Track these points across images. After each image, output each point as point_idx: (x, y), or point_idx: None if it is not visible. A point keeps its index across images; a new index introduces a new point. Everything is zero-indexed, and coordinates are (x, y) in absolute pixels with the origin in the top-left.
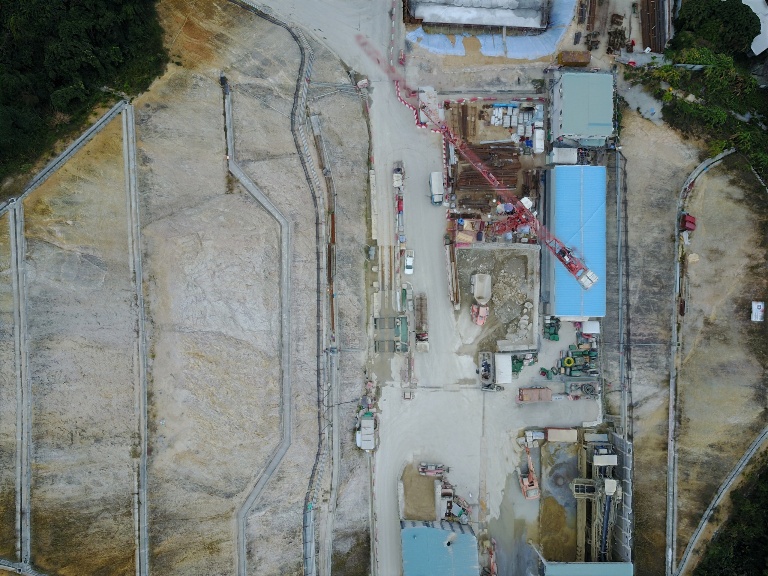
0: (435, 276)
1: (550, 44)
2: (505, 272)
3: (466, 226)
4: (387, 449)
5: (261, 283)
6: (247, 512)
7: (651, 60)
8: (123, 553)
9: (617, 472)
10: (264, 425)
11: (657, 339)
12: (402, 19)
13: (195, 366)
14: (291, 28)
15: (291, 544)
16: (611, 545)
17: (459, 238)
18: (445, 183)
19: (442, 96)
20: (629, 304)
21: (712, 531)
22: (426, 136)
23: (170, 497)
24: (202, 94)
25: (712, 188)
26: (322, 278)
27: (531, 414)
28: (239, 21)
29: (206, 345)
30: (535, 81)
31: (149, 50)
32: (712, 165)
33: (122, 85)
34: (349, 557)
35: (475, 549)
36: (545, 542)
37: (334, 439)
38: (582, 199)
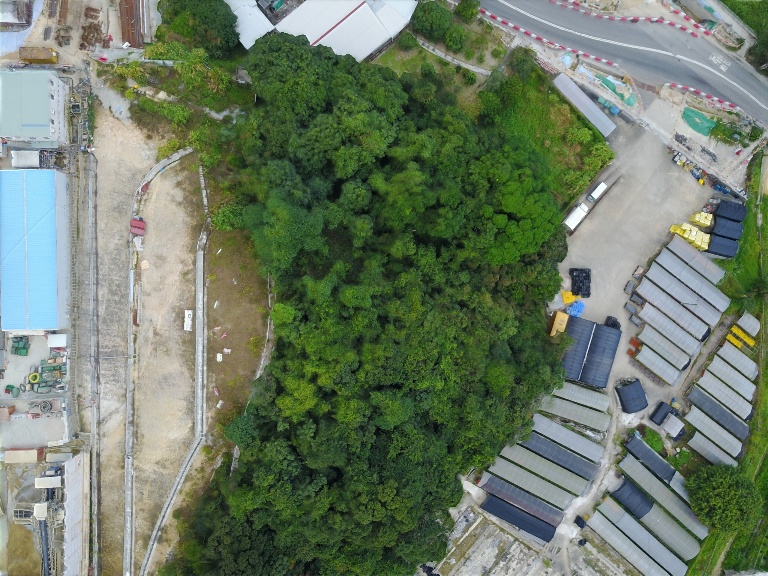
0: None
1: (21, 40)
2: None
3: None
4: None
5: None
6: None
7: (126, 56)
8: None
9: None
10: None
11: (118, 351)
12: None
13: None
14: None
15: None
16: (60, 572)
17: None
18: None
19: None
20: (98, 315)
21: (164, 552)
22: None
23: None
24: None
25: (162, 191)
26: None
27: None
28: None
29: None
30: None
31: None
32: (168, 166)
33: None
34: None
35: None
36: (10, 570)
37: None
38: (26, 205)
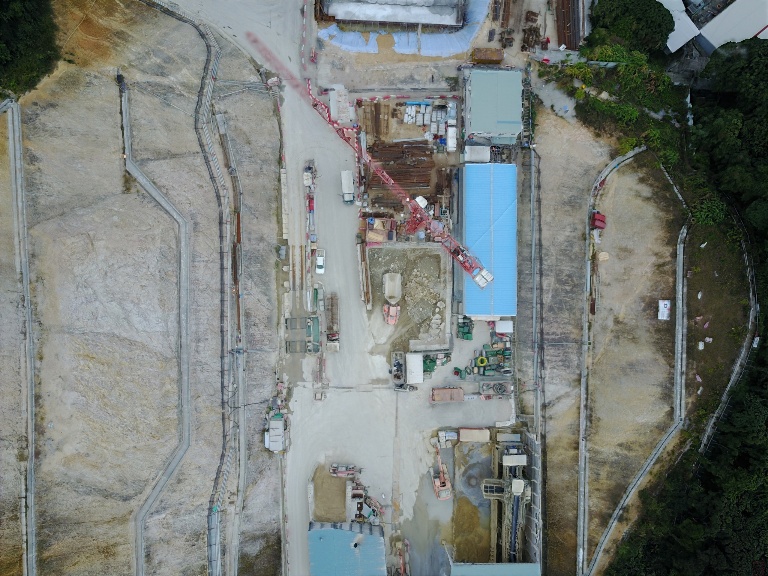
0: (347, 276)
1: (465, 41)
2: (417, 271)
3: (377, 225)
4: (298, 450)
5: (156, 283)
6: (145, 515)
7: (565, 57)
8: (9, 558)
9: (527, 472)
10: (160, 427)
11: (569, 338)
12: (314, 16)
13: (85, 368)
14: (199, 25)
15: (194, 547)
16: (521, 545)
17: (369, 237)
18: (357, 182)
19: (355, 94)
20: (542, 303)
21: (622, 531)
22: None
23: (61, 501)
24: (97, 92)
25: (622, 186)
26: (227, 278)
27: (444, 414)
28: (143, 18)
29: (97, 346)
30: (449, 79)
31: (40, 48)
32: (623, 163)
33: (9, 83)
34: (258, 559)
35: (382, 550)
36: (458, 543)
37: (240, 441)
38: (492, 197)
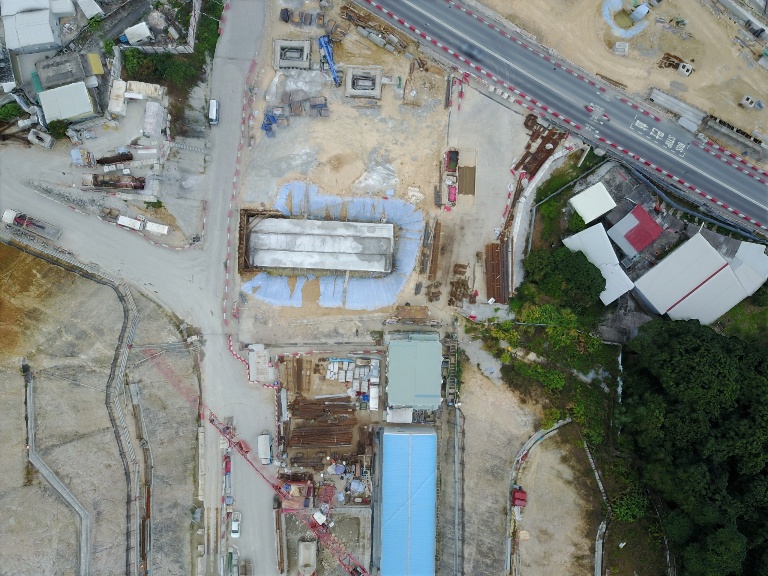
0: (264, 538)
1: (391, 293)
2: (335, 536)
3: (293, 491)
4: None
5: None
6: None
7: (493, 313)
8: None
9: None
10: None
11: None
12: (237, 270)
13: None
14: (118, 286)
15: None
16: None
17: (285, 504)
18: (276, 441)
19: (277, 349)
20: (464, 572)
21: None
22: (259, 391)
23: None
24: None
25: (544, 463)
26: (134, 557)
27: None
28: (59, 287)
29: None
30: (374, 333)
31: None
32: (547, 435)
33: None
34: None
35: None
36: None
37: None
38: (410, 470)
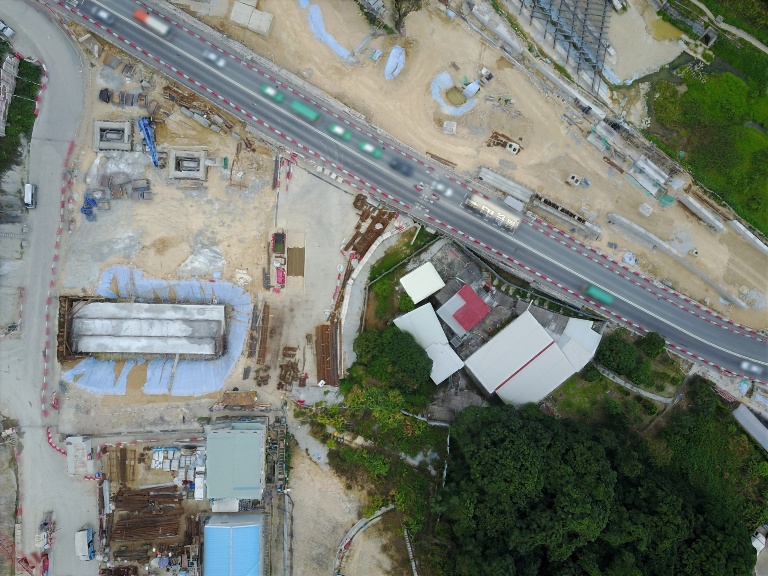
0: None
1: (220, 378)
2: None
3: None
4: None
5: None
6: None
7: (322, 396)
8: None
9: None
10: None
11: None
12: (57, 359)
13: None
14: None
15: None
16: None
17: None
18: (98, 535)
19: (99, 439)
20: None
21: None
22: (80, 483)
23: None
24: None
25: (366, 552)
26: None
27: None
28: None
29: None
30: (201, 419)
31: None
32: (370, 523)
33: None
34: None
35: None
36: None
37: None
38: (231, 563)
